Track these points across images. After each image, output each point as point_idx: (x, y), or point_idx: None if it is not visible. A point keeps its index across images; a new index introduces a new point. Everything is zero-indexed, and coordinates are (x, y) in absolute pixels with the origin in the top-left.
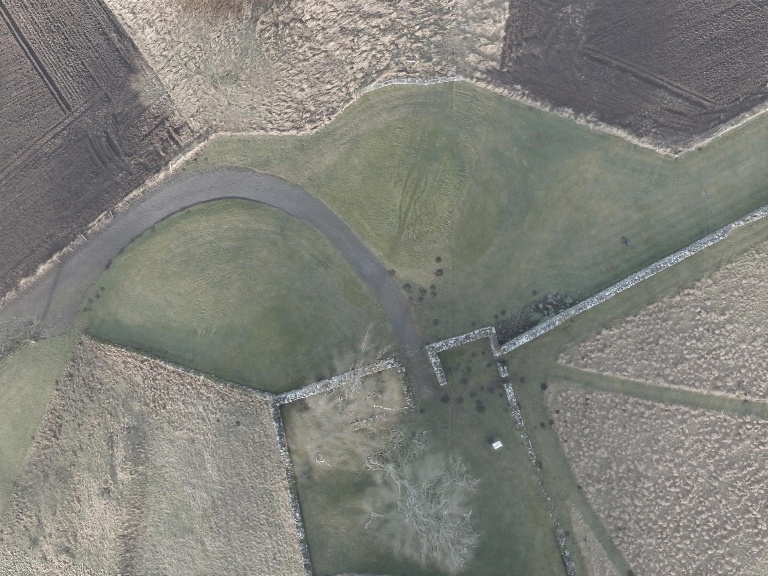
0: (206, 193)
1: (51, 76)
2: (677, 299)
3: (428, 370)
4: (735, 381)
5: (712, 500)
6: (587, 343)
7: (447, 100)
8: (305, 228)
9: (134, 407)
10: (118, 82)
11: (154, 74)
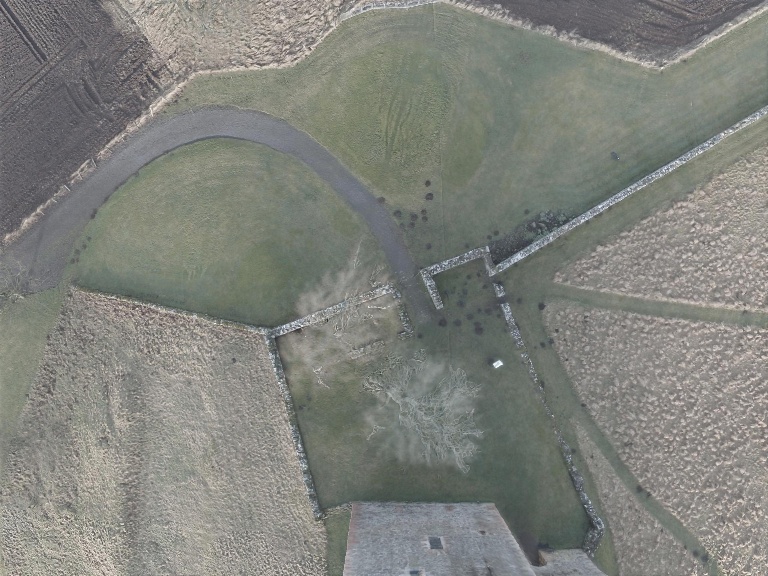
0: (189, 134)
1: (24, 26)
2: (671, 212)
3: (424, 295)
4: (733, 292)
5: (717, 412)
6: (583, 261)
7: (427, 22)
8: (291, 162)
9: (128, 354)
10: (93, 28)
11: (129, 17)
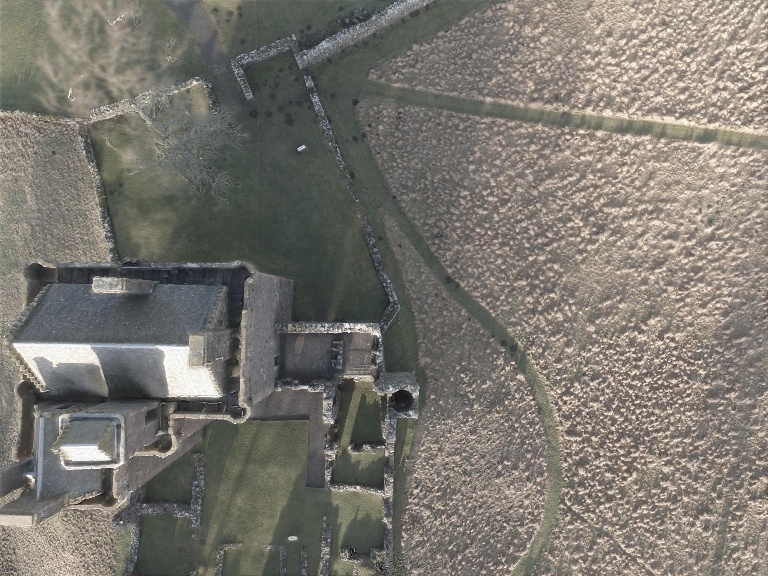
0: None
1: None
2: (489, 14)
3: (235, 87)
4: (553, 94)
5: (532, 209)
6: (398, 59)
7: None
8: None
9: None
10: None
11: None
